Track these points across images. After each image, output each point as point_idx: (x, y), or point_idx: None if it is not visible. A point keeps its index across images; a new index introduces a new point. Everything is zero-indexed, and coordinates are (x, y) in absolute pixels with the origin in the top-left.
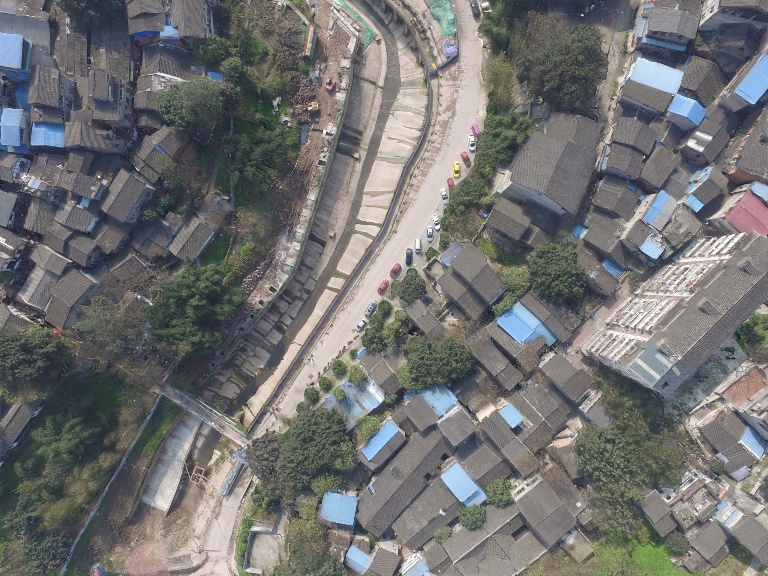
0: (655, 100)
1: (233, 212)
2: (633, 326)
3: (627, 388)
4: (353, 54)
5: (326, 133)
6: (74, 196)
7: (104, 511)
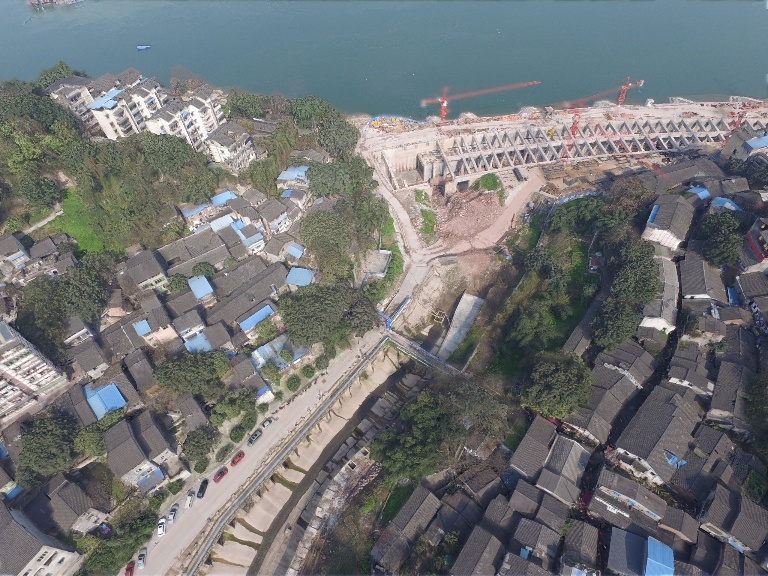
0: None
1: None
2: (3, 381)
3: (34, 334)
4: None
5: None
6: (537, 563)
7: (510, 291)
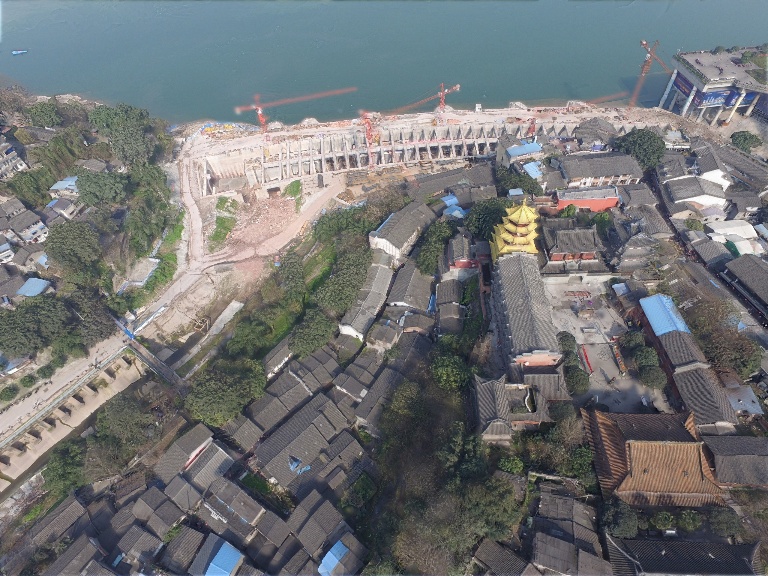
0: None
1: None
2: None
3: None
4: None
5: None
6: (124, 569)
7: None
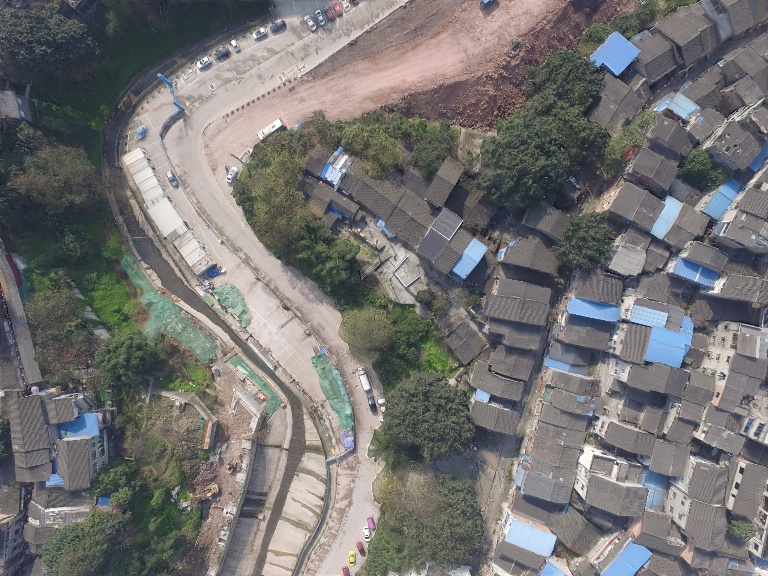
0: (529, 560)
1: None
2: None
3: None
4: (255, 433)
5: (226, 512)
6: None
7: None
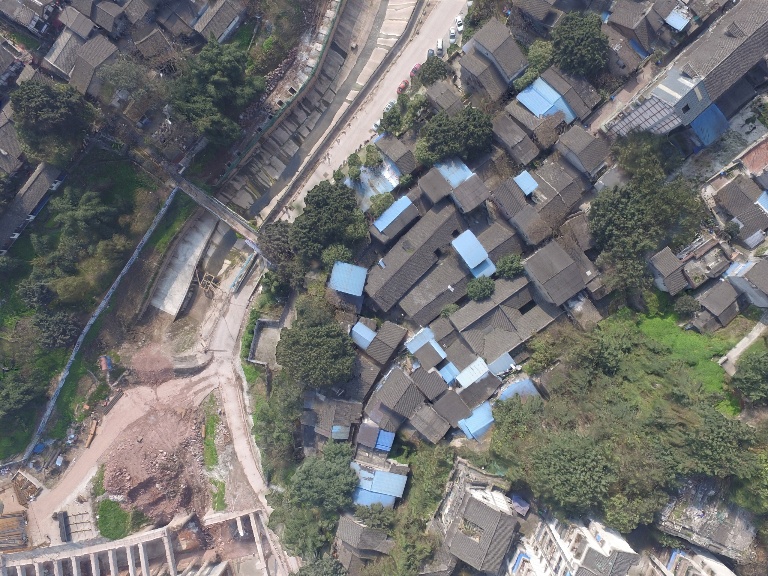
0: None
1: (258, 1)
2: None
3: (646, 136)
4: None
5: None
6: None
7: (114, 305)
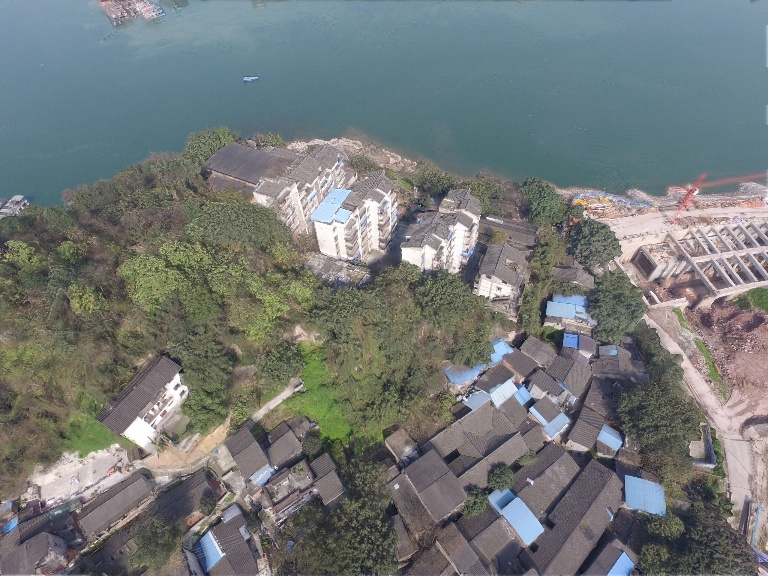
0: None
1: None
2: None
3: None
4: None
5: None
6: None
7: None
